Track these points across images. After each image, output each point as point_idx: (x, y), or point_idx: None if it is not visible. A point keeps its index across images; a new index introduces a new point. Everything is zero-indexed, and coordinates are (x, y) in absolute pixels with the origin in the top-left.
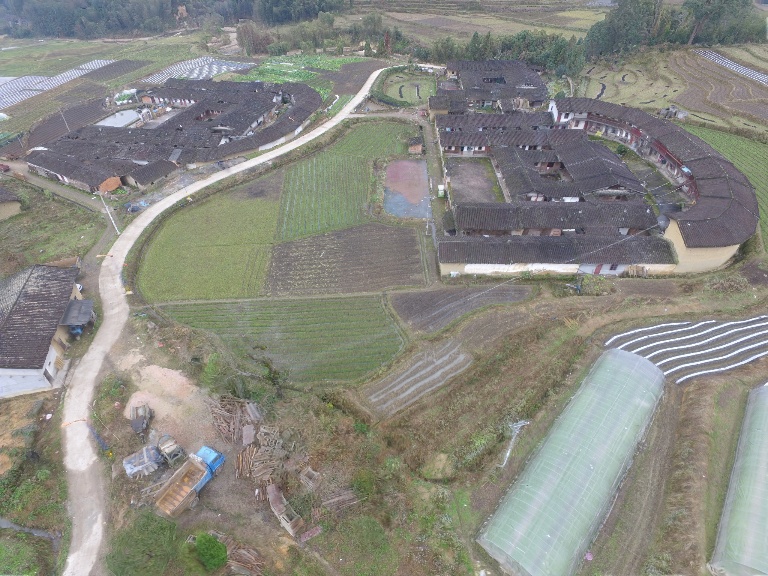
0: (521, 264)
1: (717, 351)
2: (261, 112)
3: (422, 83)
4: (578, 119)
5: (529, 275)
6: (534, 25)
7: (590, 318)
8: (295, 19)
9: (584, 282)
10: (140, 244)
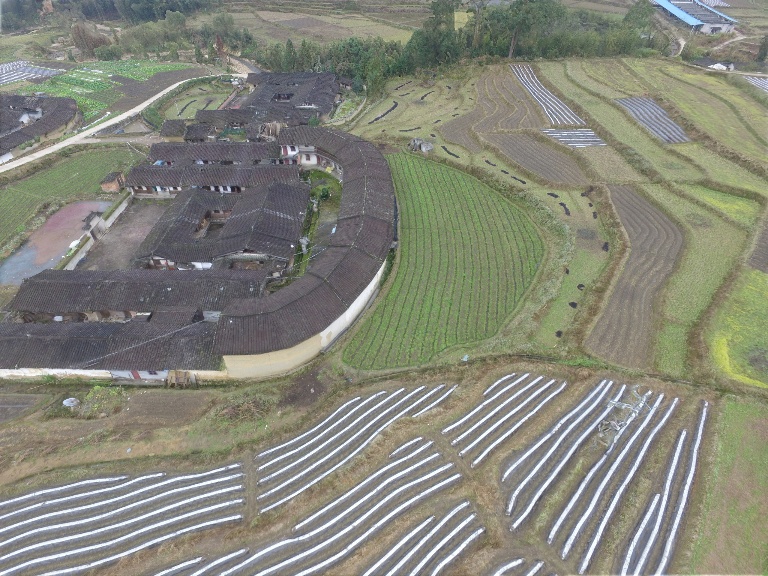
0: (32, 368)
1: (110, 531)
2: None
3: (219, 97)
4: (305, 152)
5: (56, 379)
6: (400, 28)
7: (14, 465)
8: (159, 17)
9: (85, 398)
10: None
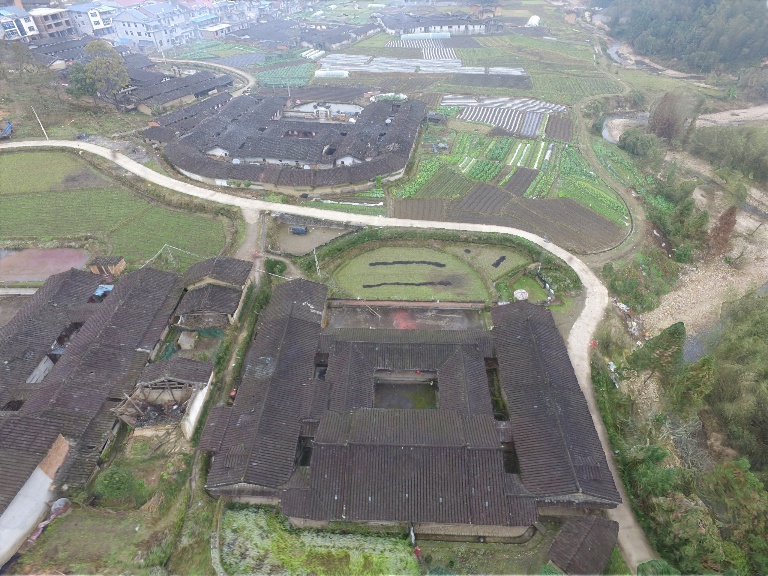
0: None
1: None
2: (290, 156)
3: (465, 290)
4: None
5: None
6: None
7: None
8: None
9: None
10: (27, 149)
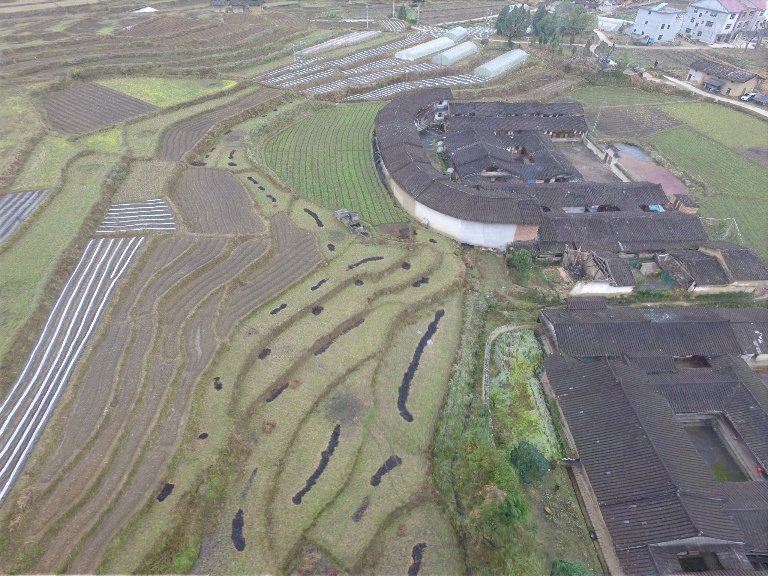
0: None
1: None
2: None
3: None
4: None
5: None
6: None
7: None
8: None
9: None
10: None
